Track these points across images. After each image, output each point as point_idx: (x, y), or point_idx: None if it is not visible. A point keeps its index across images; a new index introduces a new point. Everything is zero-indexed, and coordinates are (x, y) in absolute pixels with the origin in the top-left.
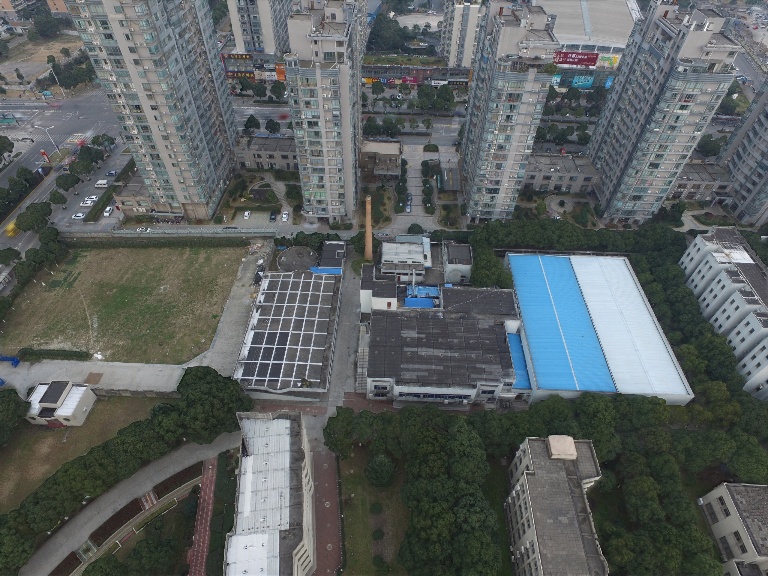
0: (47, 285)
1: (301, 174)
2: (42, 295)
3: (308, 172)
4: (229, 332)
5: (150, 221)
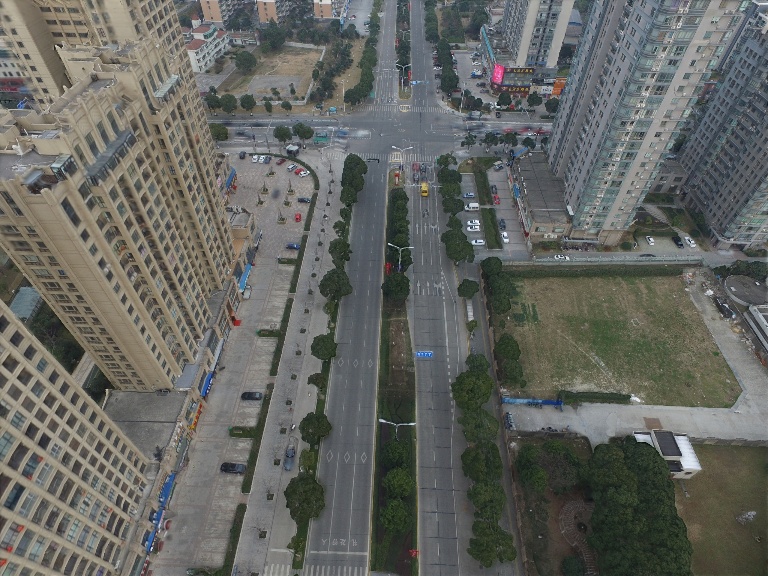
0: (512, 319)
1: (754, 201)
2: (517, 330)
3: (763, 199)
4: (747, 371)
5: (557, 248)
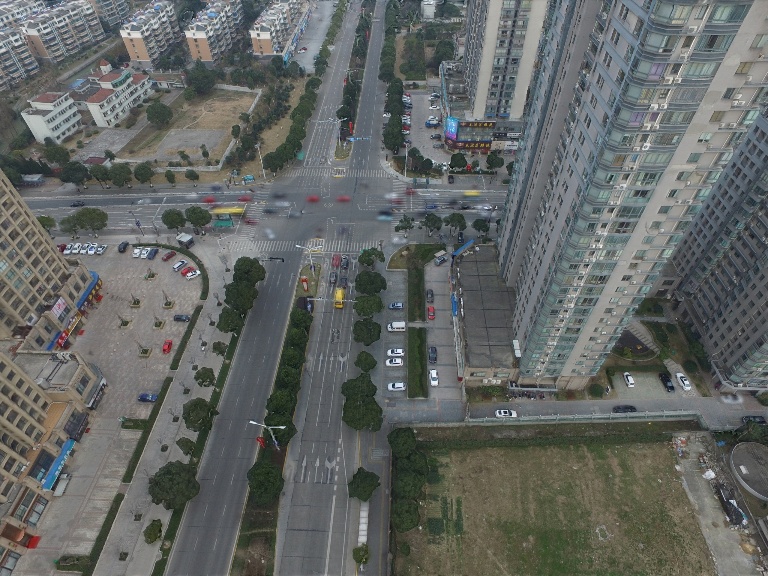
0: (425, 528)
1: None
2: (429, 551)
3: None
4: None
5: (502, 395)
